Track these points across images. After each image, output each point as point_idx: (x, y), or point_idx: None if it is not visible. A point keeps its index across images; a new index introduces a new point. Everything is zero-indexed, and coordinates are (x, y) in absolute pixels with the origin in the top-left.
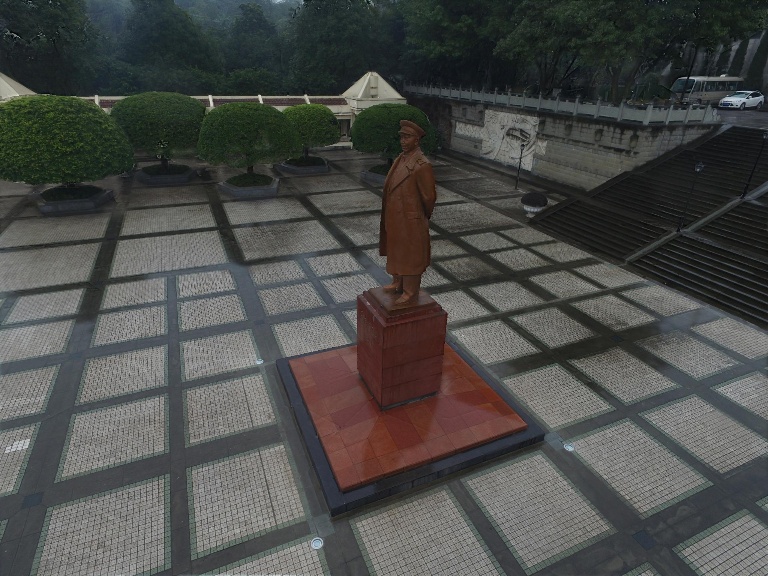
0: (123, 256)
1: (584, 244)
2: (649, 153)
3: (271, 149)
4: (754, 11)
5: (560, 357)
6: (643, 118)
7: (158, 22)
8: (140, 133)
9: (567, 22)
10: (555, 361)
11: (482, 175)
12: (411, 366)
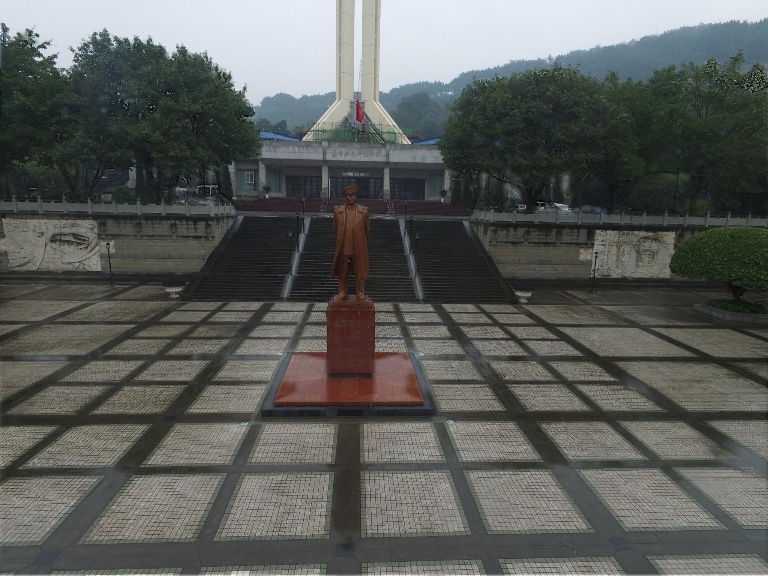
0: None
1: (246, 299)
2: (218, 236)
3: None
4: (250, 146)
5: None
6: (209, 212)
7: None
8: None
9: (138, 139)
10: None
11: (48, 284)
12: None
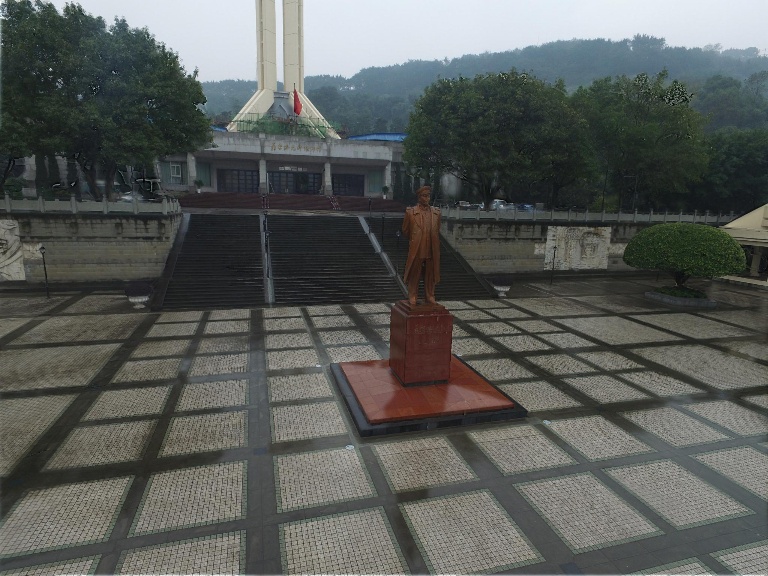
0: None
1: (227, 306)
2: (172, 237)
3: None
4: (205, 137)
5: (380, 342)
6: (162, 210)
7: None
8: None
9: None
10: None
11: None
12: None
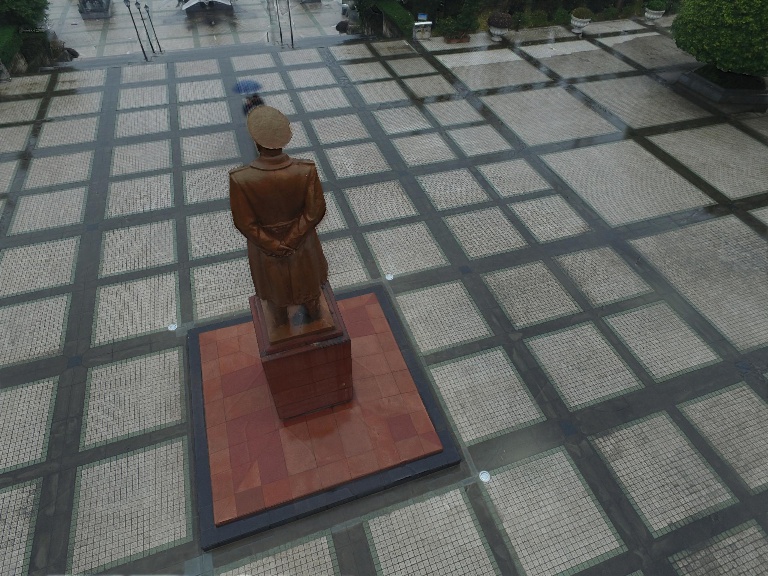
0: (592, 151)
1: None
2: None
3: None
4: None
5: None
6: None
7: None
8: None
9: None
10: None
11: None
12: None
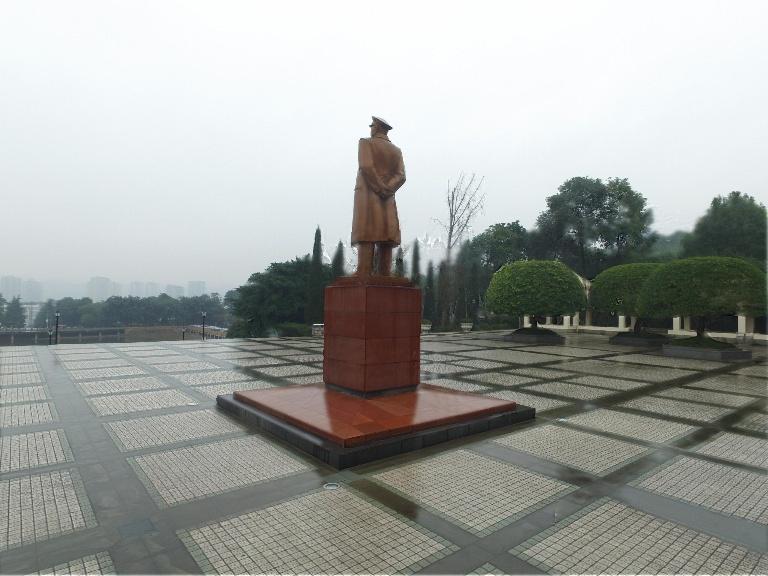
0: None
1: None
2: None
3: (706, 300)
4: None
5: (609, 490)
6: None
7: (722, 221)
8: (603, 292)
9: None
10: (583, 485)
11: None
12: (341, 341)
